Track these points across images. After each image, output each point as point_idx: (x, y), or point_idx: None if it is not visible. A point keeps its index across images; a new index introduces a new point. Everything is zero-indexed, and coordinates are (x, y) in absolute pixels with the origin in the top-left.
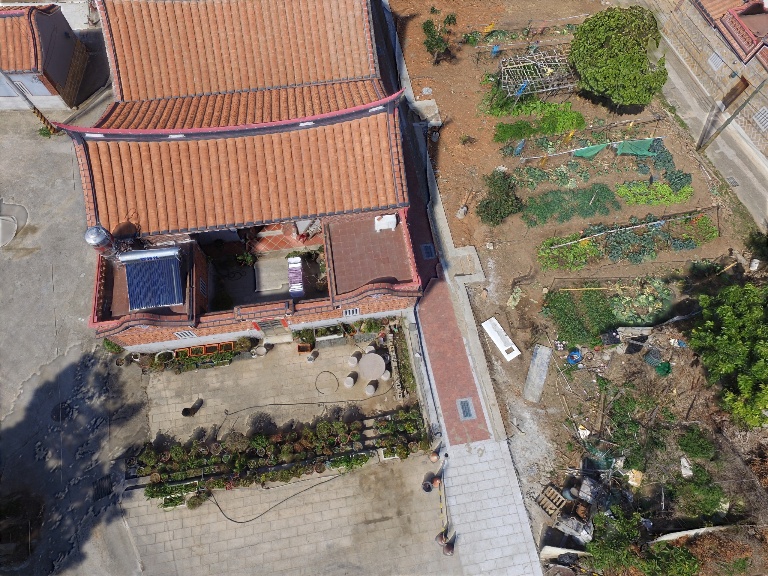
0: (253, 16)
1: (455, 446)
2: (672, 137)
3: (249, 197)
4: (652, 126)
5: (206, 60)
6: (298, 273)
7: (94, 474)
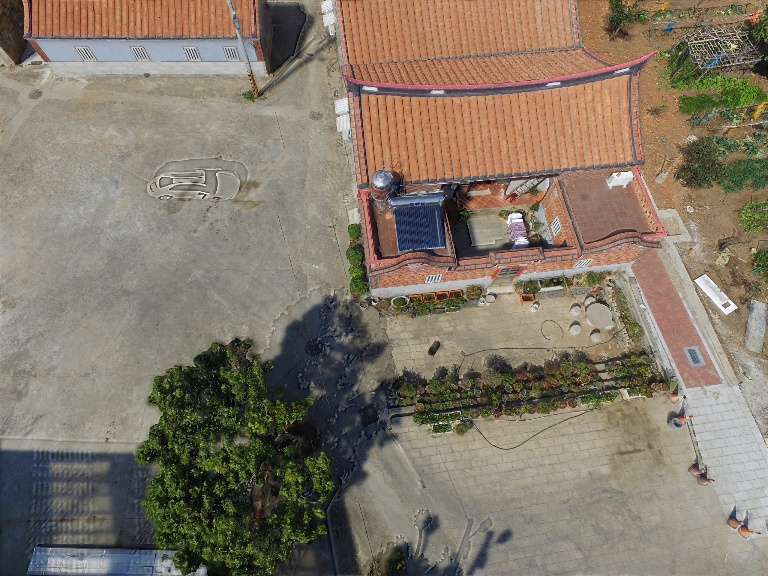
0: None
1: (691, 389)
2: None
3: (499, 151)
4: None
5: (423, 28)
6: (522, 228)
7: (358, 403)
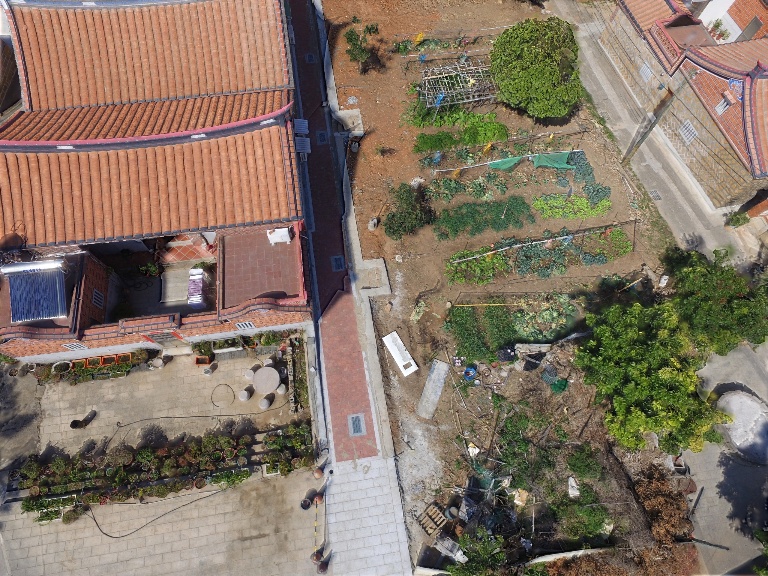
0: (165, 25)
1: (341, 462)
2: (596, 149)
3: (139, 209)
4: (577, 138)
5: (117, 69)
6: (198, 285)
7: None
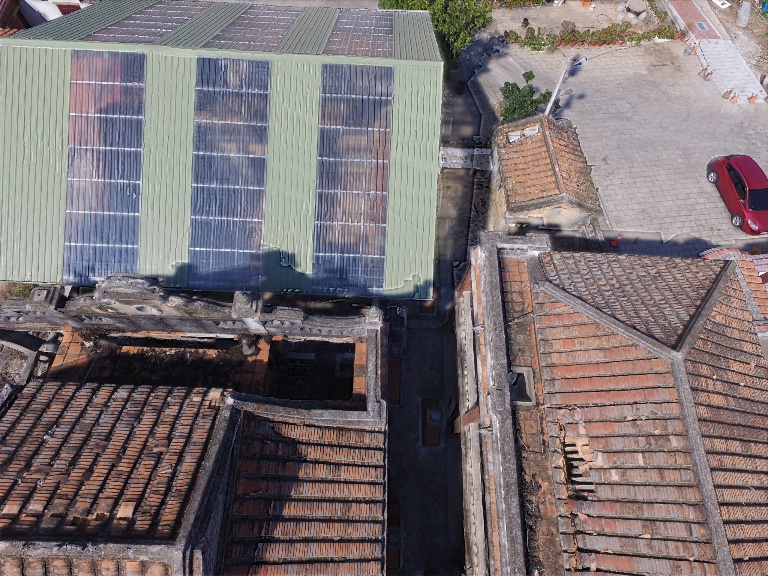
0: None
1: (699, 40)
2: None
3: None
4: None
5: None
6: None
7: (479, 42)
